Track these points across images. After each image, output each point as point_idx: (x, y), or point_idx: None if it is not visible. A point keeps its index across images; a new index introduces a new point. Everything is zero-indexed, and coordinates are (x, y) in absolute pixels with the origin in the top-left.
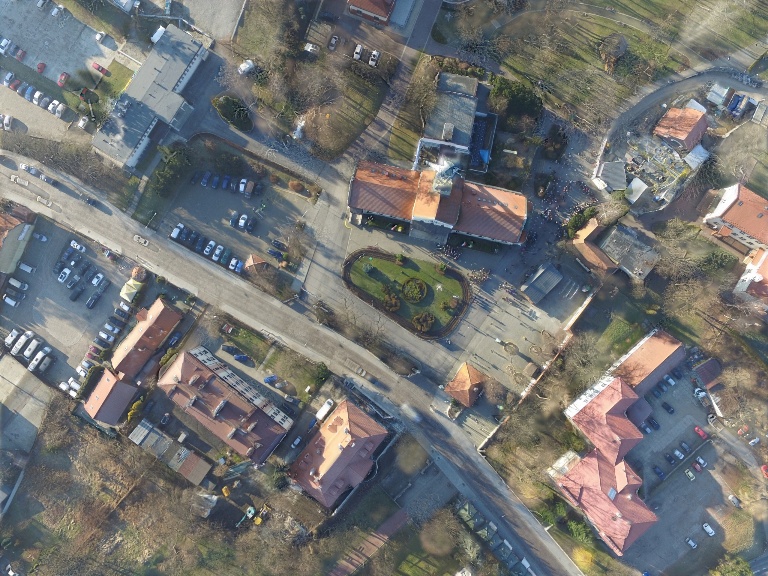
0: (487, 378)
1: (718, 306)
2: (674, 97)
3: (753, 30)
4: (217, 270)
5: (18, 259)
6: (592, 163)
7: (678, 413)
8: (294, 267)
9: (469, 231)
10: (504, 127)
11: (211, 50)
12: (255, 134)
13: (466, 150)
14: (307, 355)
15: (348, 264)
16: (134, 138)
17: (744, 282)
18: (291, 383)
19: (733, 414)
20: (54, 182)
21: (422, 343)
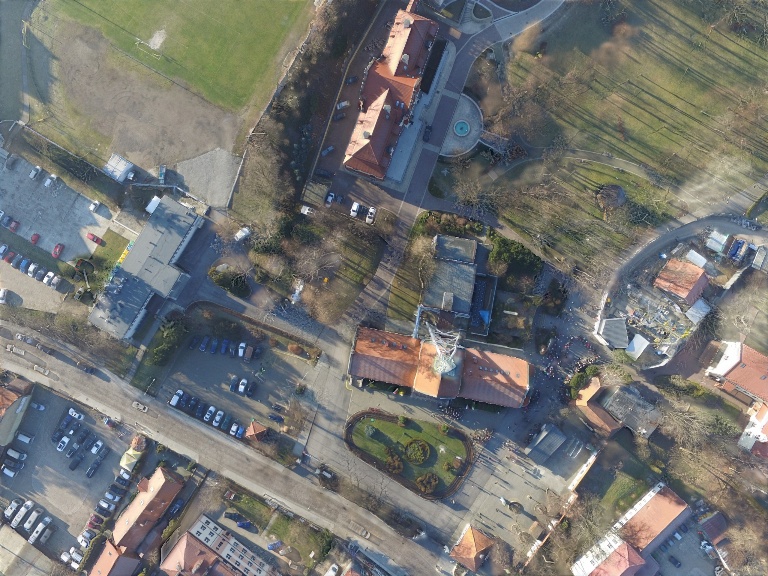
0: (493, 542)
1: (723, 458)
2: (673, 245)
3: (751, 171)
4: (218, 435)
5: (16, 429)
6: (593, 317)
7: (685, 566)
8: (295, 430)
9: (471, 397)
10: (504, 287)
11: (207, 217)
12: (253, 299)
13: (466, 315)
14: (310, 519)
15: (350, 426)
16: (131, 313)
17: (748, 437)
18: (295, 548)
19: (740, 568)
20: (51, 352)
21: (426, 503)
